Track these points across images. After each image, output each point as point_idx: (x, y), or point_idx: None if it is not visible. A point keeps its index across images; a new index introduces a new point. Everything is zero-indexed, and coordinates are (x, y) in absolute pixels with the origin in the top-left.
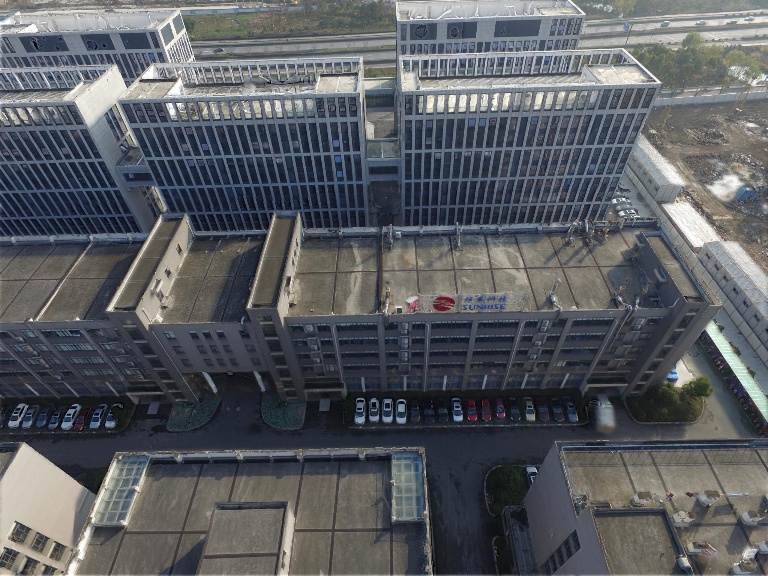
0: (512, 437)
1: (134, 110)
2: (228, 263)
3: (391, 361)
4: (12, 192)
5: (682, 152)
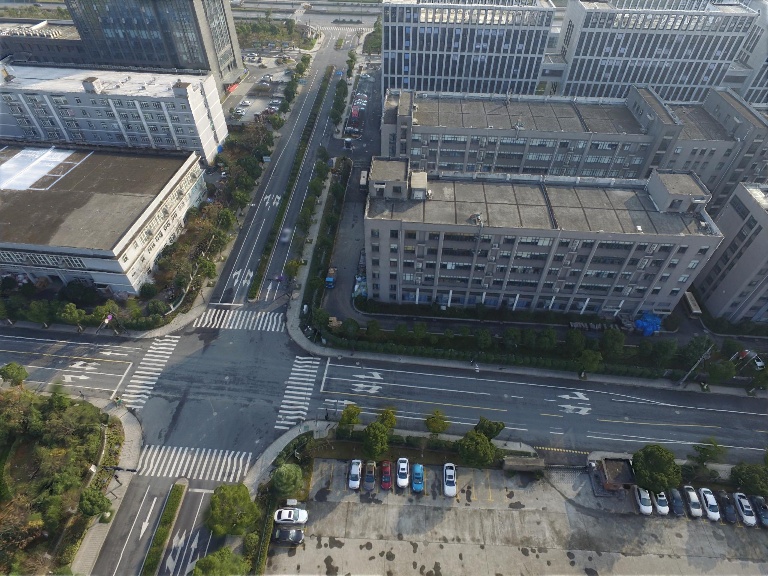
0: None
1: (592, 17)
2: (685, 117)
3: None
4: (458, 78)
5: None
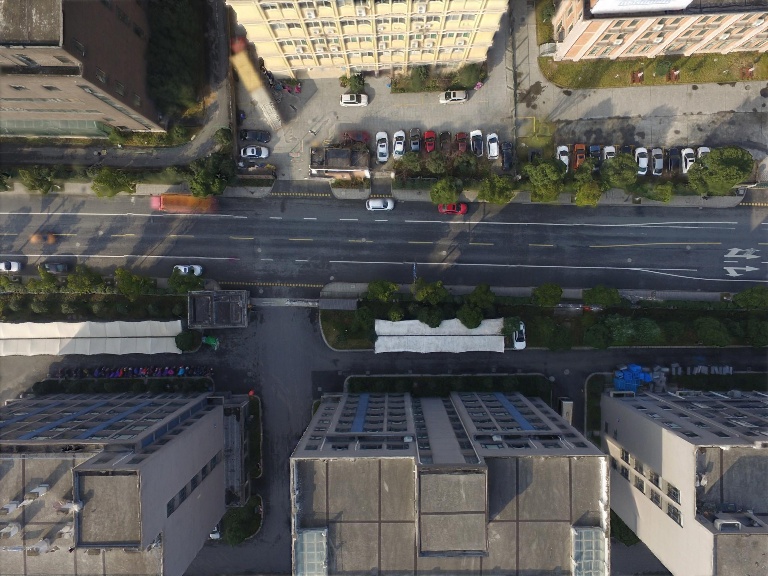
0: (228, 568)
1: None
2: None
3: None
4: None
5: None
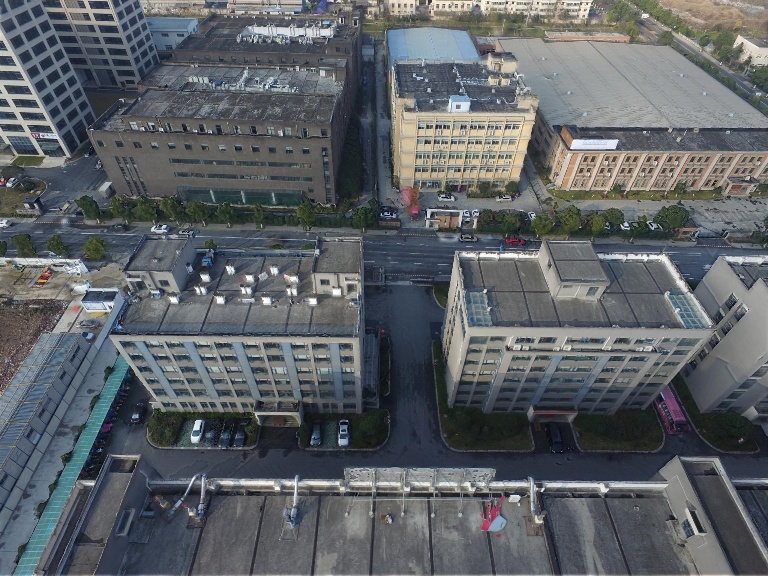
0: None
1: None
2: None
3: None
4: None
5: None
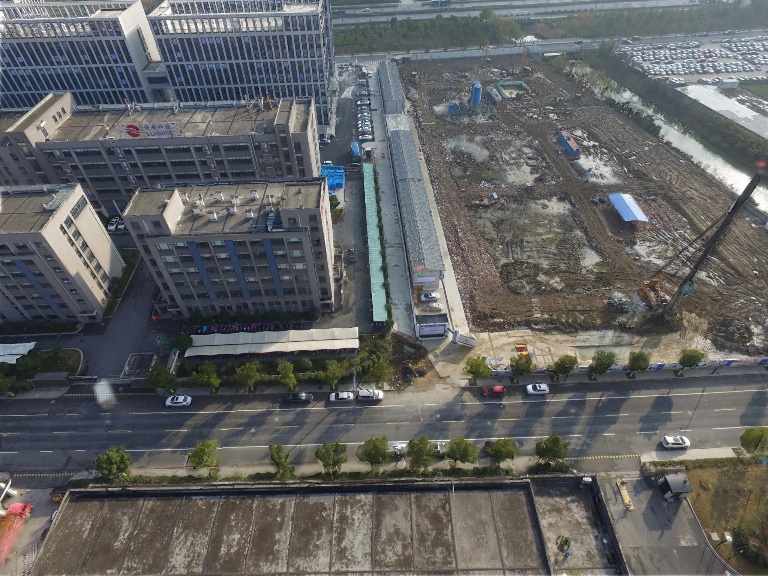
0: None
1: None
2: None
3: (126, 185)
4: None
5: (430, 87)
